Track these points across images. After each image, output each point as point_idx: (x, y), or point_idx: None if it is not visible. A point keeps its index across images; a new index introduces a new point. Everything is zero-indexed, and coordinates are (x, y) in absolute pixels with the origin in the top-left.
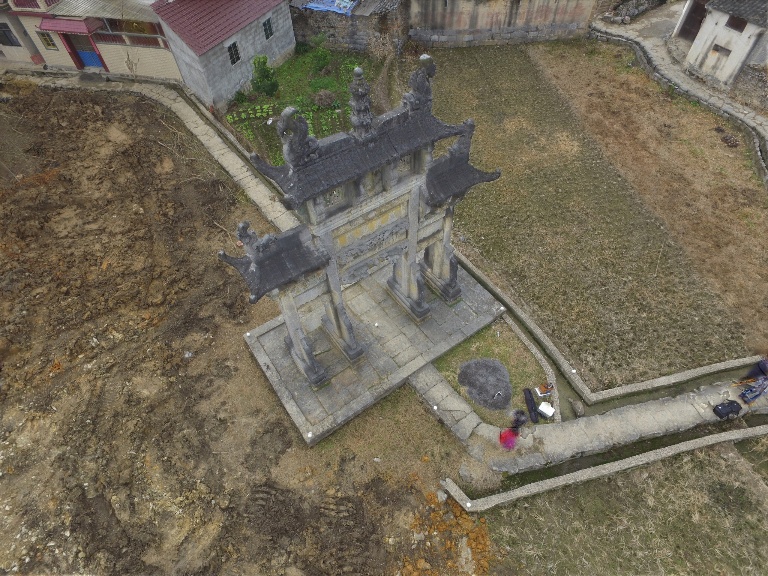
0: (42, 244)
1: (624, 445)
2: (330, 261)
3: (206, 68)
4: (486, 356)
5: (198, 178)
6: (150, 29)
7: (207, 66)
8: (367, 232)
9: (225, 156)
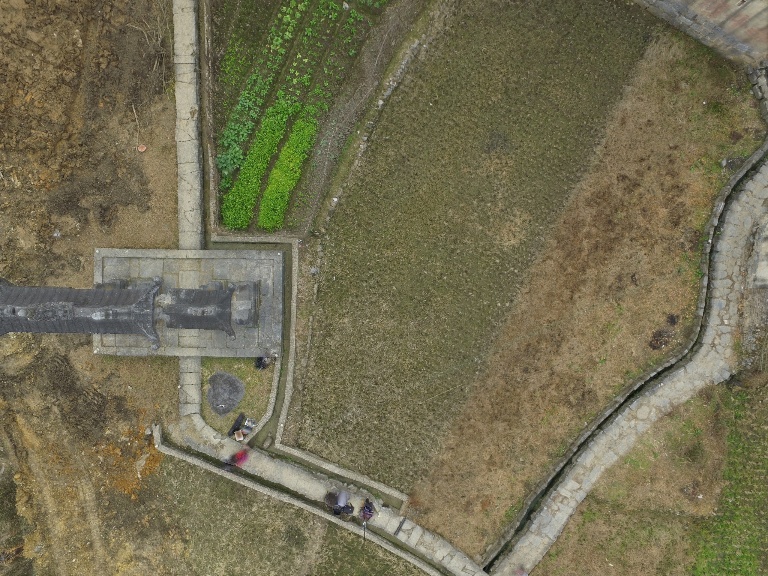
0: None
1: None
2: None
3: None
4: (240, 377)
5: (144, 32)
6: None
7: None
8: None
9: (183, 14)
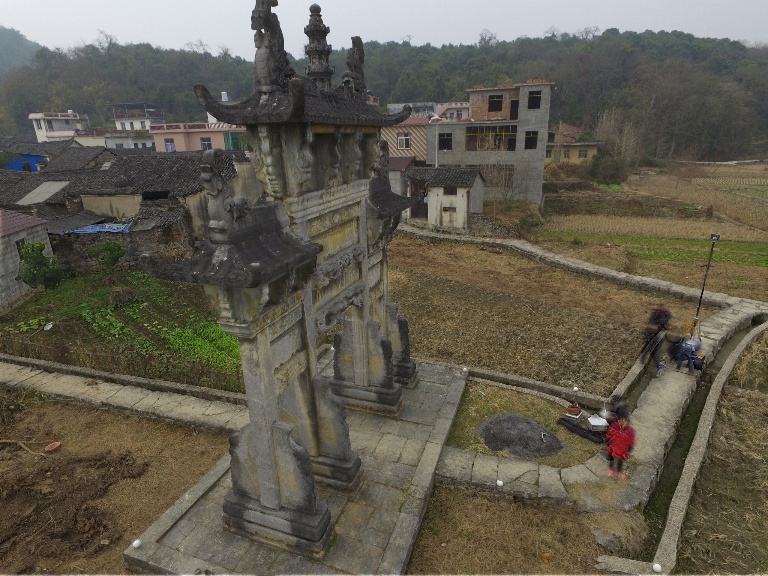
0: None
1: (679, 425)
2: None
3: None
4: (492, 414)
5: None
6: None
7: None
8: (331, 250)
9: None
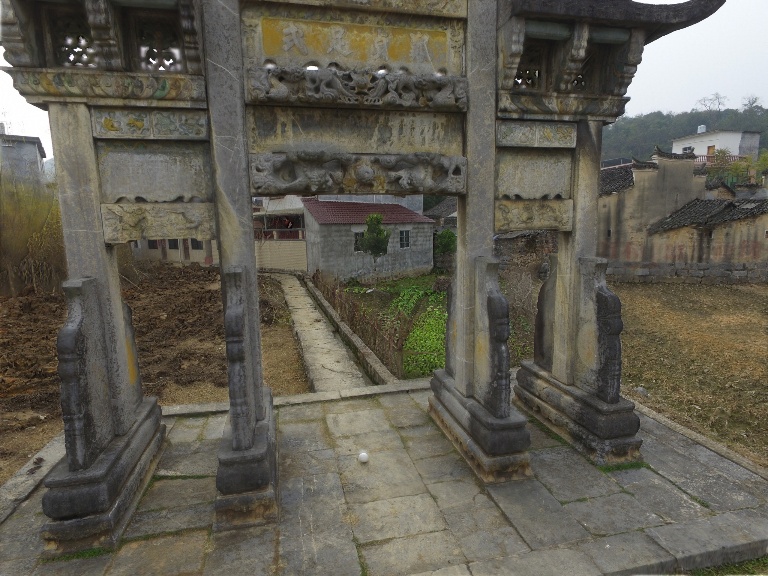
0: (33, 318)
1: None
2: (223, 72)
3: (324, 239)
4: None
5: None
6: (296, 223)
7: (326, 238)
8: (346, 59)
9: (297, 298)
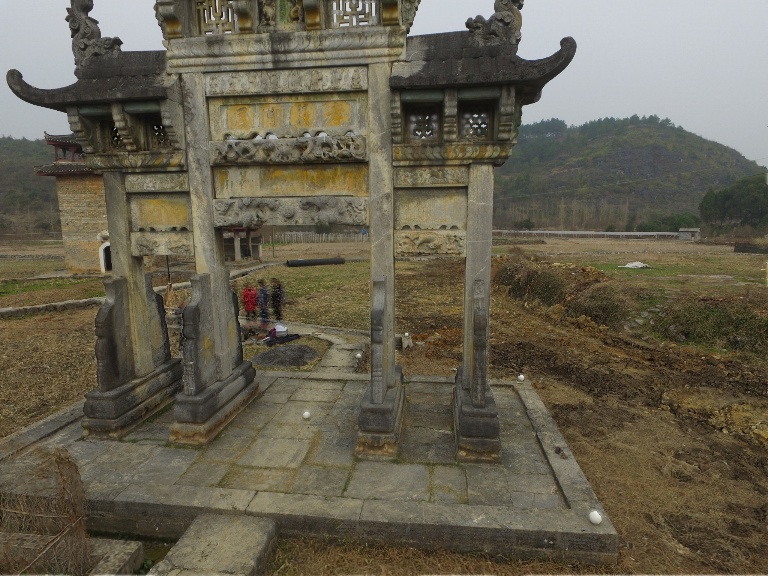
0: None
1: None
2: None
3: None
4: None
5: None
6: None
7: None
8: None
9: None
